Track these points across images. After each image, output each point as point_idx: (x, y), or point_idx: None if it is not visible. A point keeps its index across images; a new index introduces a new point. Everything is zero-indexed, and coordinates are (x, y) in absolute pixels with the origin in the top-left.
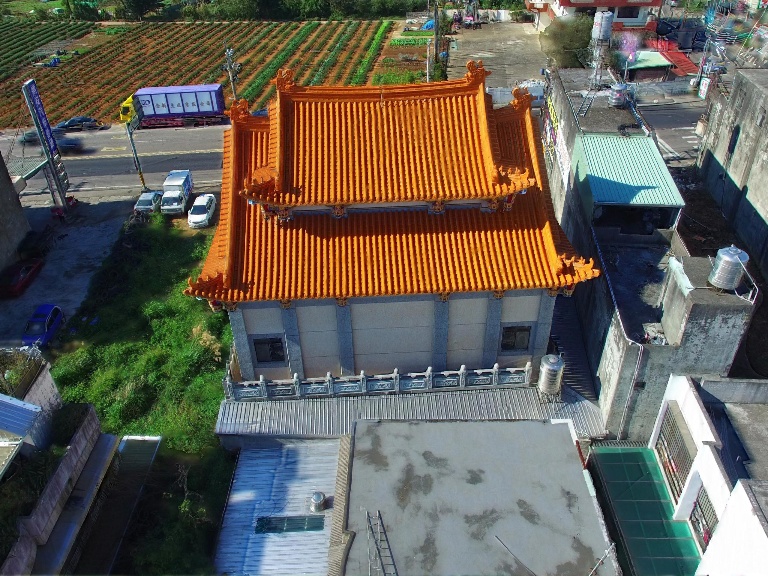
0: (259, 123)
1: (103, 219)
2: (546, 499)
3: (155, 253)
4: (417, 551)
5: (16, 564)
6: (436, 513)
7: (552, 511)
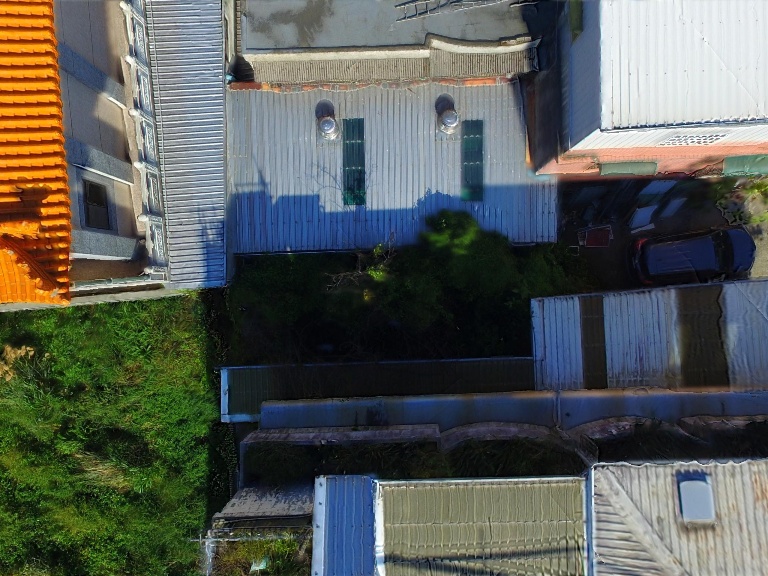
0: None
1: None
2: None
3: None
4: None
5: None
6: None
7: None
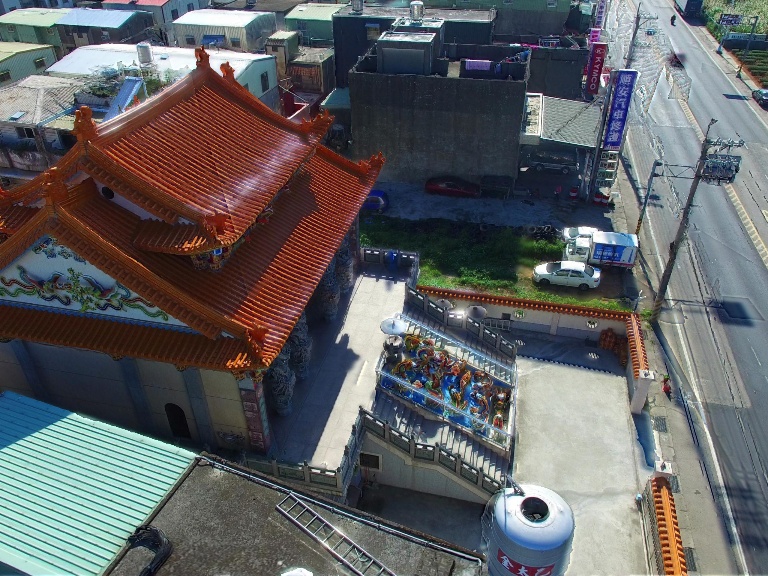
0: None
1: (567, 221)
2: None
3: (474, 247)
4: None
5: None
6: None
7: None
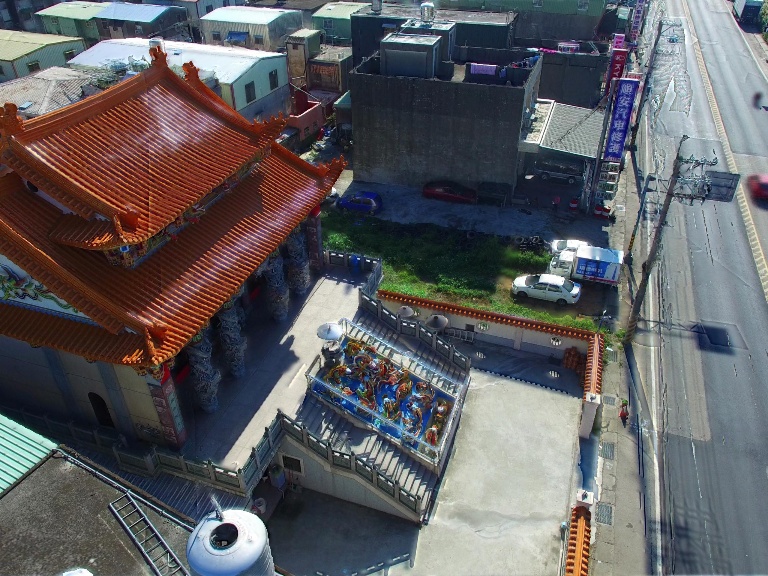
0: None
1: (562, 233)
2: None
3: (458, 254)
4: None
5: None
6: None
7: None
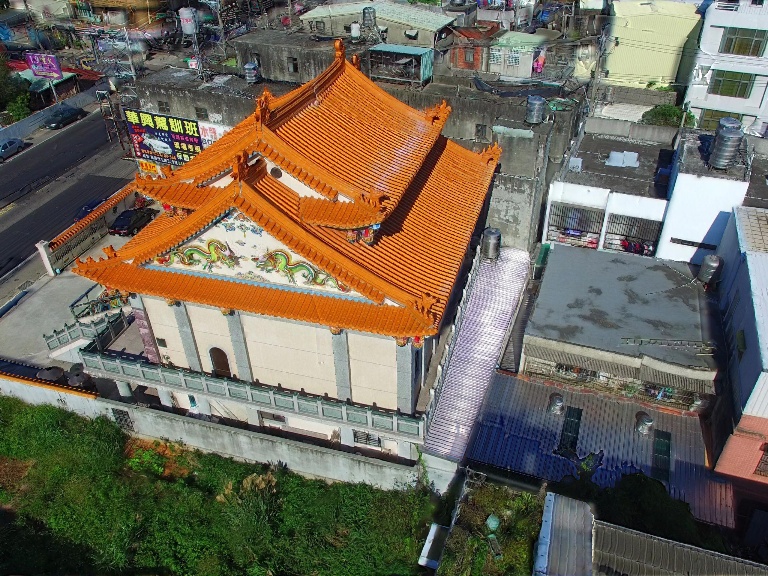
0: (256, 172)
1: None
2: (618, 269)
3: None
4: (657, 328)
5: None
6: (626, 314)
7: (627, 270)
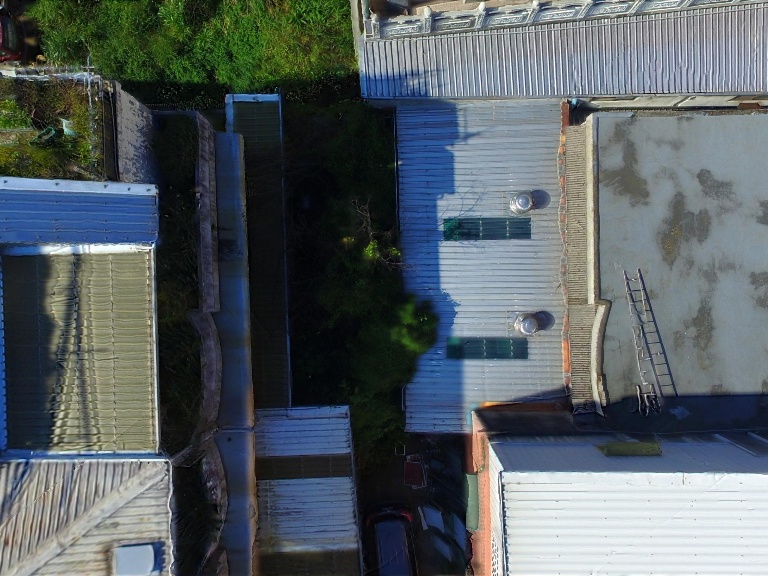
0: None
1: None
2: None
3: None
4: (689, 325)
5: (208, 358)
6: (714, 271)
7: None
